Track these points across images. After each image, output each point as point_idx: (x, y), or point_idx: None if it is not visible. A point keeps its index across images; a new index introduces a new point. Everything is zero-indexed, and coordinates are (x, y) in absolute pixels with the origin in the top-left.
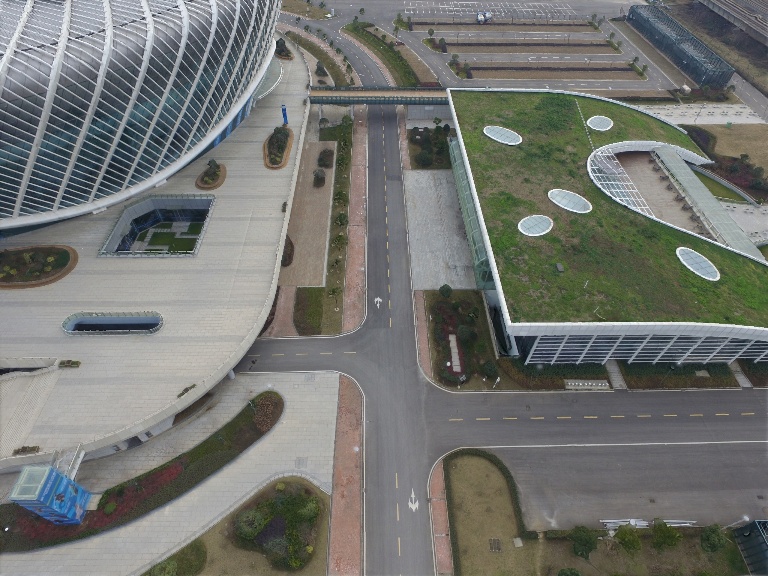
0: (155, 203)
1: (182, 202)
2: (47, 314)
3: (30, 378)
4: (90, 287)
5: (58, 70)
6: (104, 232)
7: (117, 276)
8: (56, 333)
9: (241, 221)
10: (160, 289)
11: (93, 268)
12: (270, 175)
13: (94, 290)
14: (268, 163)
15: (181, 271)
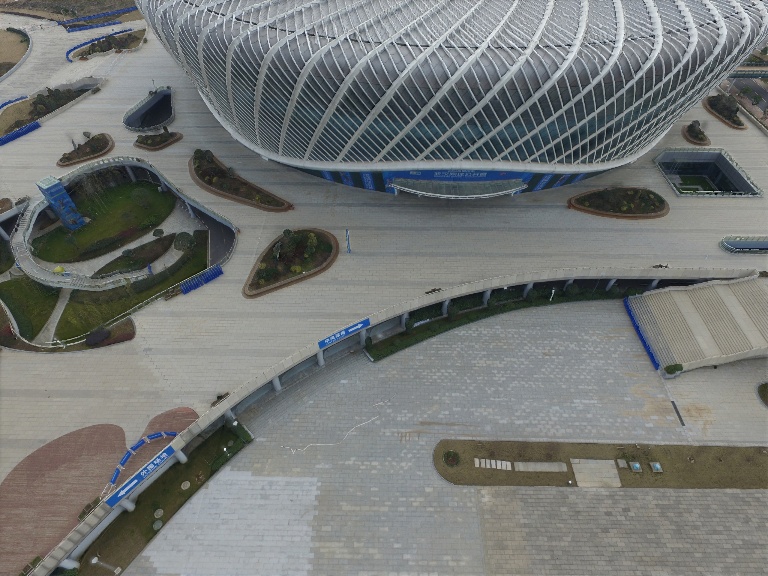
0: (664, 156)
1: (689, 156)
2: (693, 238)
3: (725, 286)
4: (702, 219)
5: (764, 27)
6: (658, 177)
7: (714, 211)
8: (719, 252)
9: (766, 170)
10: (764, 221)
11: (685, 205)
12: (744, 134)
13: (708, 221)
14: (733, 124)
15: (764, 208)
